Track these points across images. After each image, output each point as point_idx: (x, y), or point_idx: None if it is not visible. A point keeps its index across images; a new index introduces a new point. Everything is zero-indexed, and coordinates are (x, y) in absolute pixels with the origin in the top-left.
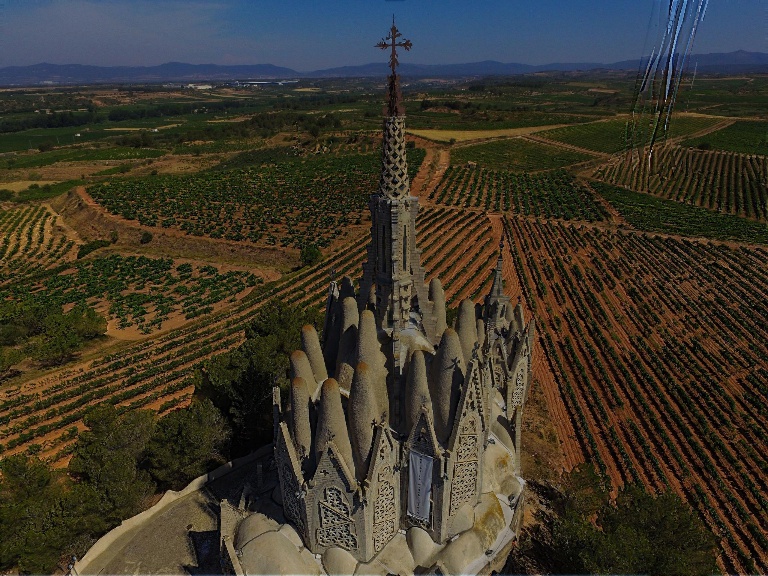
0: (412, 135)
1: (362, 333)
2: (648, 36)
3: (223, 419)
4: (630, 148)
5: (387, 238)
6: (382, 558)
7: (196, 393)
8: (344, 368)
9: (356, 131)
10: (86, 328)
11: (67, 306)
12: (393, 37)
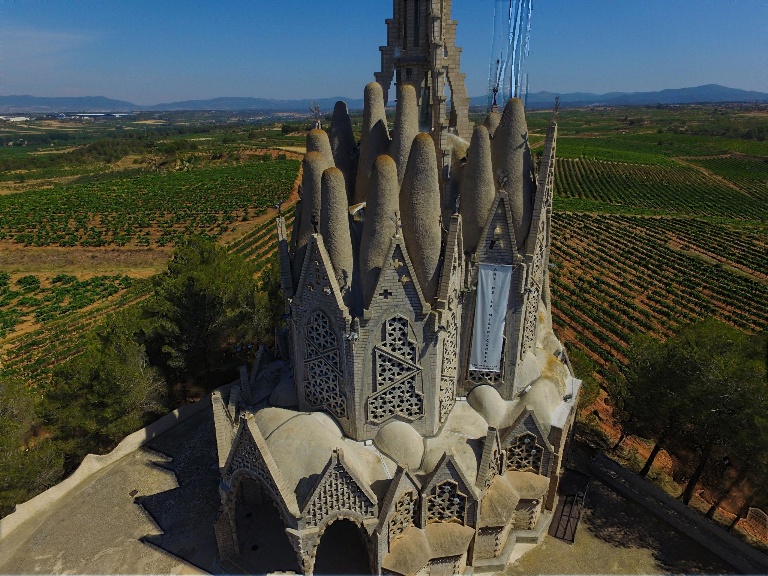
0: (282, 149)
1: (405, 113)
2: (494, 46)
3: (150, 368)
4: None
5: None
6: (451, 428)
7: None
8: None
9: (220, 146)
10: None
11: None
12: None
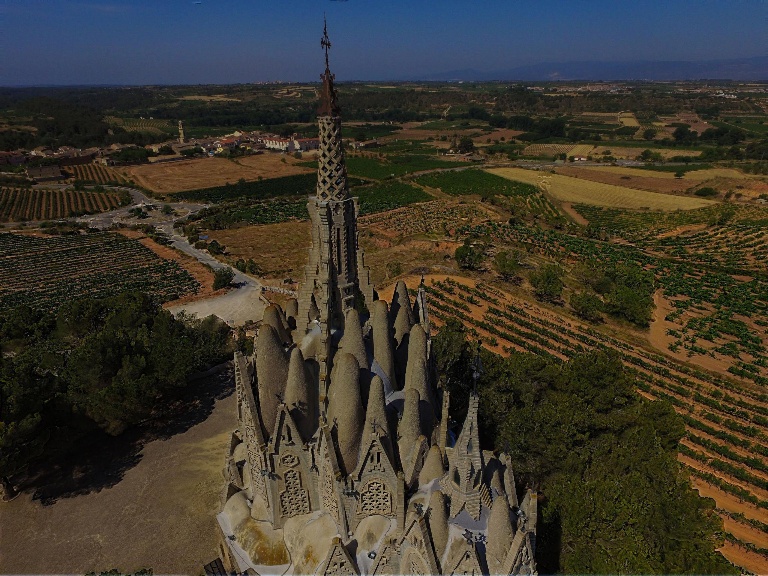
0: None
1: None
2: None
3: None
4: None
5: None
6: None
7: None
8: None
9: None
10: (629, 309)
11: (684, 297)
12: (326, 36)
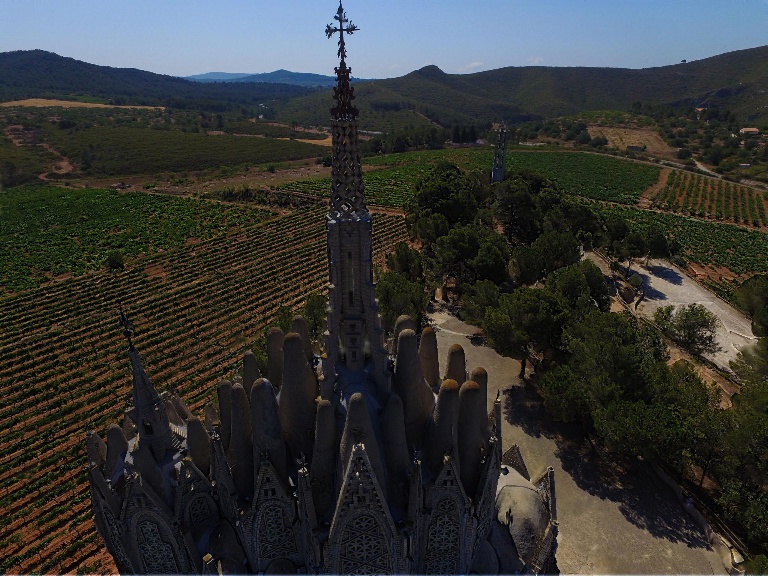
0: None
1: None
2: None
3: None
4: None
5: None
6: None
7: None
8: None
9: None
10: None
11: None
12: (341, 20)
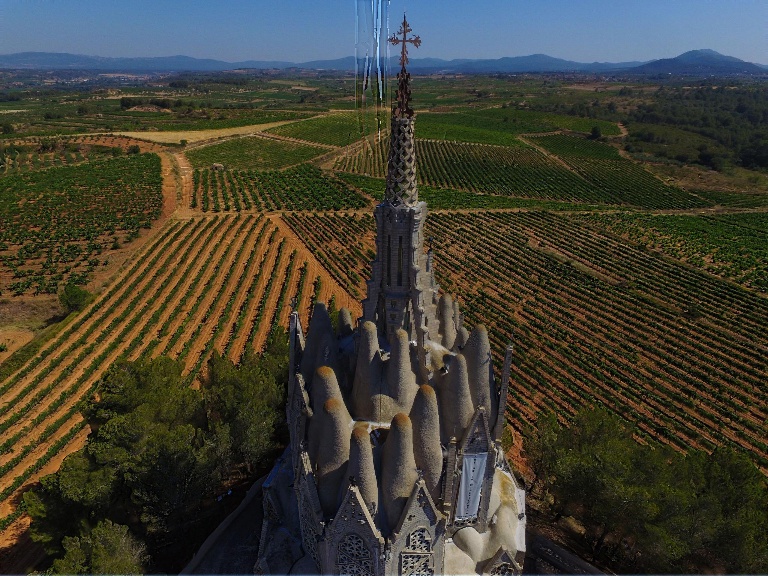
0: (132, 138)
1: (403, 355)
2: None
3: None
4: (365, 140)
5: (405, 249)
6: (449, 575)
7: (35, 526)
8: (380, 400)
9: (51, 137)
10: None
11: None
12: (405, 32)
